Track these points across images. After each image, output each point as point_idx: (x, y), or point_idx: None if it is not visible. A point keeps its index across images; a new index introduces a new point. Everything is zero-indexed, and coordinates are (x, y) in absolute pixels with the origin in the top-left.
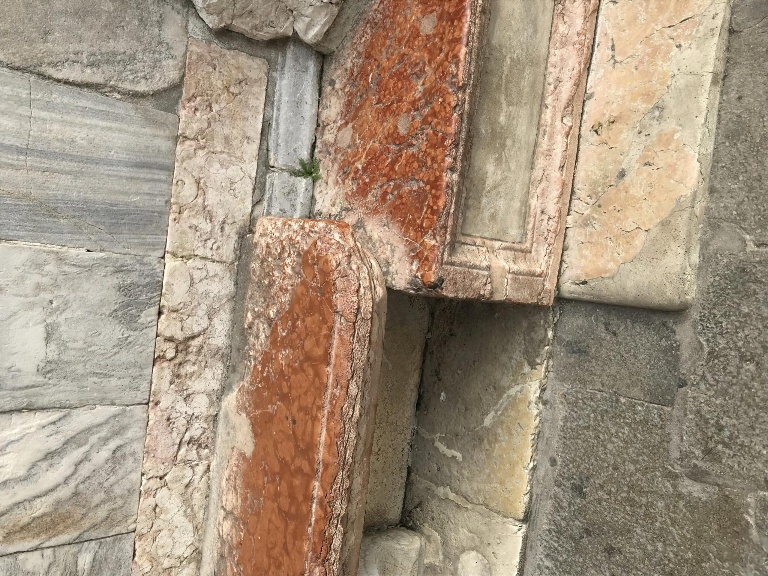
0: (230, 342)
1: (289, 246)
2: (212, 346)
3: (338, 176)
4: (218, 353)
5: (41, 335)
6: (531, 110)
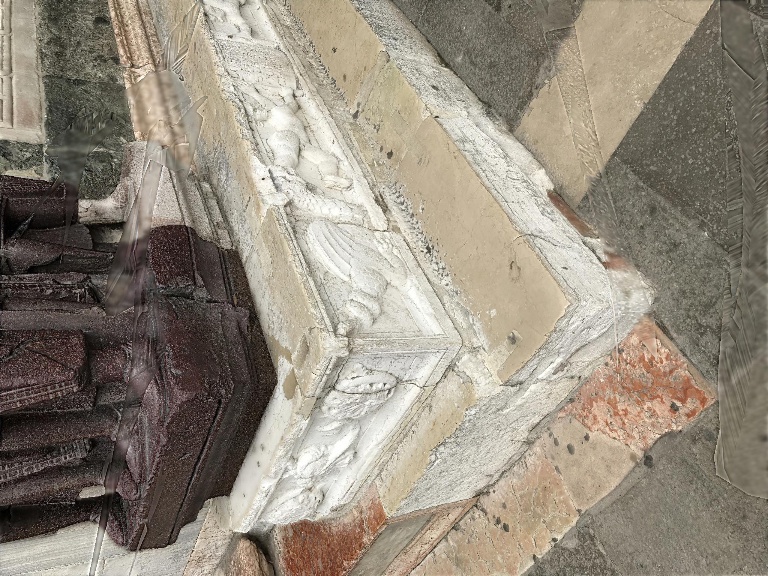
0: (226, 552)
1: (247, 575)
2: (217, 554)
3: (284, 538)
4: (219, 555)
5: (139, 569)
6: (375, 575)
